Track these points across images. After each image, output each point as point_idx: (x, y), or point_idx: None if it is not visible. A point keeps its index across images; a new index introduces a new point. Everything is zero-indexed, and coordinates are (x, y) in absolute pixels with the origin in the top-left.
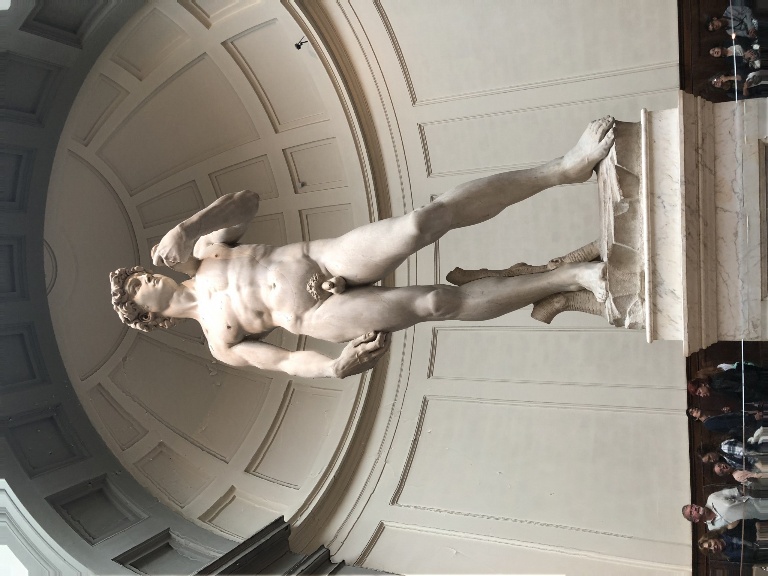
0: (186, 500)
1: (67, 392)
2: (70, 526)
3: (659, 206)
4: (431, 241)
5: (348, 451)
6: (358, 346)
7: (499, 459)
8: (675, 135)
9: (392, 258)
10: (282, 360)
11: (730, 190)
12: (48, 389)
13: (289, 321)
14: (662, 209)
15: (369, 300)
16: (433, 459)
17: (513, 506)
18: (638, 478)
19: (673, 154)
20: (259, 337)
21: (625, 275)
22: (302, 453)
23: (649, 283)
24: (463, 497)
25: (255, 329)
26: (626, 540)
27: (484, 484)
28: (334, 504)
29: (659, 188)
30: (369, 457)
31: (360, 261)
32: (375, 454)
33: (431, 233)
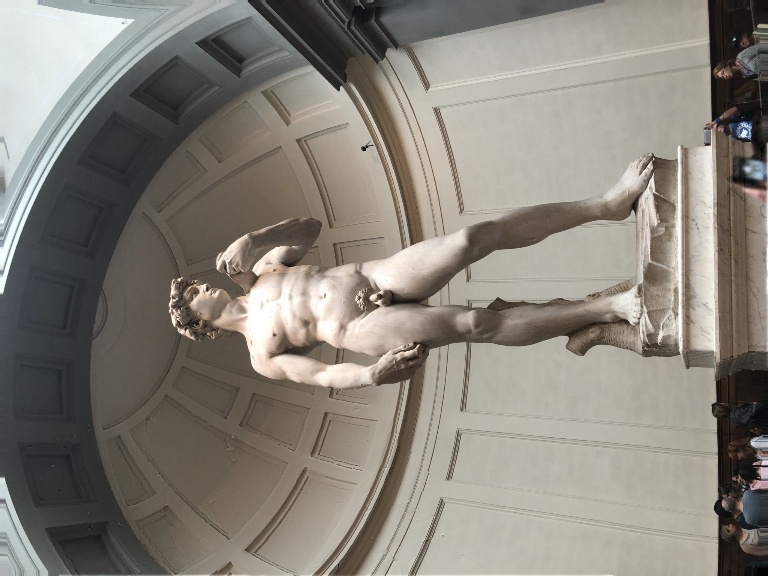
0: (180, 568)
1: (88, 436)
2: (63, 561)
3: (693, 228)
4: (478, 256)
5: (356, 542)
6: (397, 354)
7: (514, 570)
8: (709, 168)
9: (440, 272)
10: (319, 371)
11: (759, 215)
12: (71, 428)
13: (333, 330)
14: (696, 230)
15: (413, 312)
16: (444, 563)
17: None
18: None
19: (707, 183)
20: (300, 353)
21: (660, 290)
22: None
23: (682, 295)
24: None
25: (298, 340)
26: None
27: None
28: None
29: (693, 212)
30: (376, 553)
31: (409, 274)
32: (383, 550)
33: (479, 247)
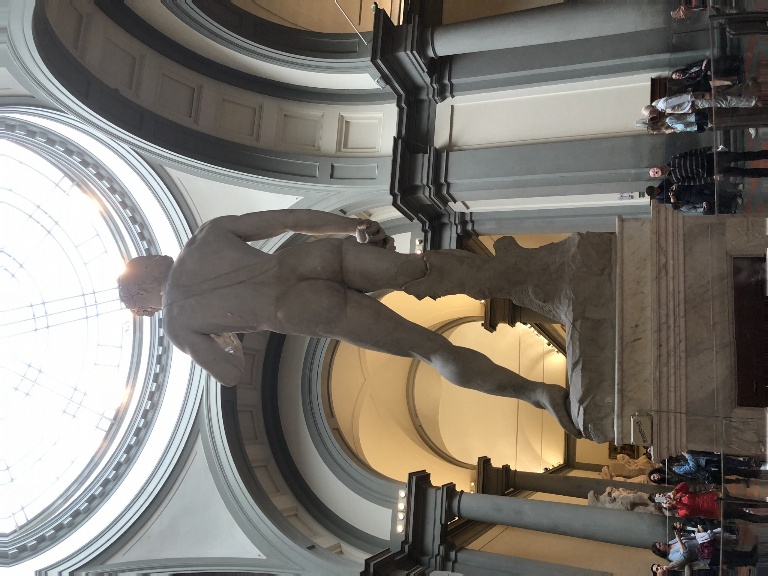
0: None
1: None
2: None
3: None
4: None
5: None
6: None
7: None
8: None
9: None
10: None
11: None
12: None
13: None
14: None
15: None
16: None
17: None
18: None
19: None
20: None
21: None
22: None
23: None
24: None
25: None
26: None
27: None
28: None
29: None
30: None
31: None
32: None
33: None
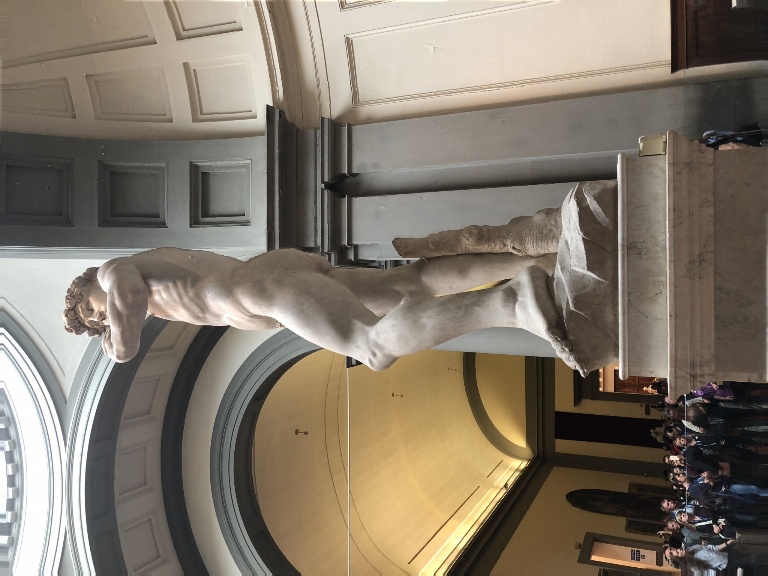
0: (164, 107)
1: None
2: (137, 227)
3: None
4: None
5: None
6: None
7: None
8: None
9: None
10: None
11: None
12: None
13: None
14: None
15: None
16: None
17: None
18: None
19: None
20: None
21: None
22: None
23: None
24: None
25: None
26: None
27: None
28: (290, 40)
29: None
30: None
31: None
32: None
33: None
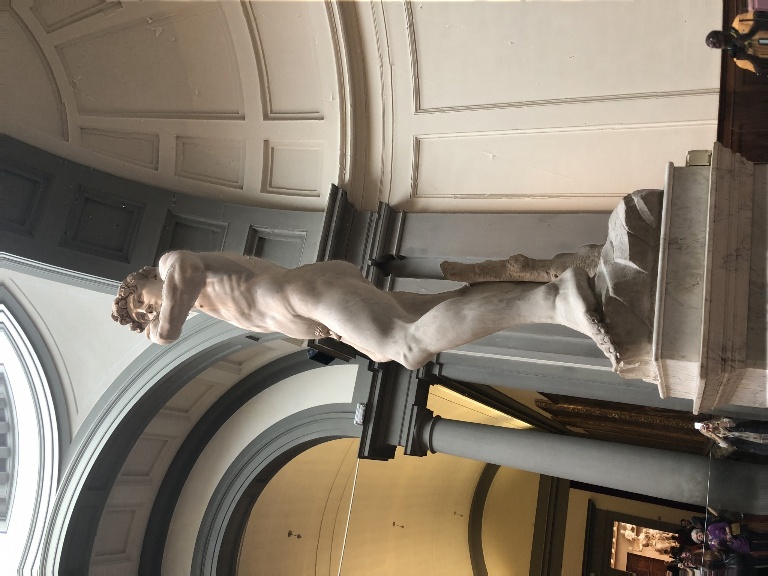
0: (238, 175)
1: (72, 167)
2: None
3: (674, 378)
4: None
5: (349, 69)
6: None
7: (507, 26)
8: (695, 368)
9: None
10: None
11: None
12: (59, 183)
13: None
14: (677, 379)
15: None
16: (437, 43)
17: (534, 83)
18: (665, 13)
19: None
20: None
21: None
22: (303, 76)
23: None
24: (481, 83)
25: None
26: (651, 102)
27: (498, 58)
28: (364, 132)
29: (674, 375)
30: (371, 59)
31: None
32: (376, 58)
33: None
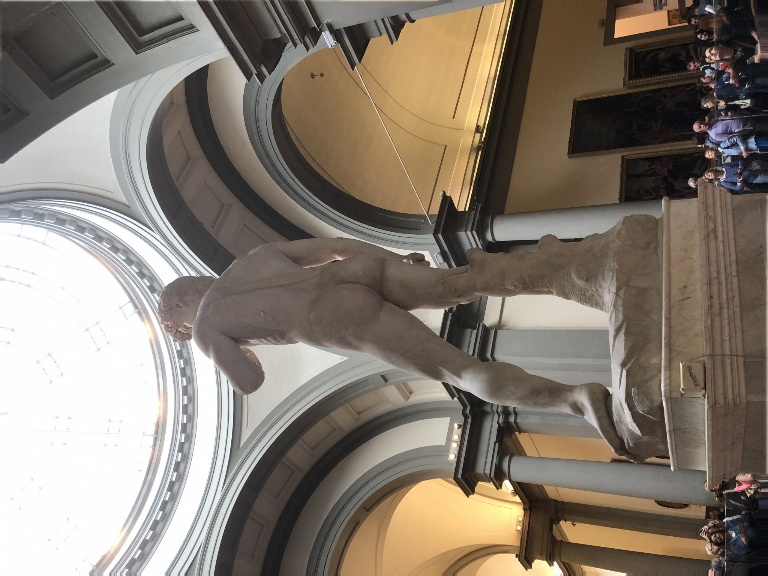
0: None
1: None
2: (86, 79)
3: None
4: None
5: None
6: None
7: None
8: None
9: None
10: None
11: None
12: None
13: None
14: None
15: None
16: None
17: None
18: None
19: None
20: None
21: None
22: None
23: None
24: None
25: None
26: None
27: None
28: None
29: None
30: None
31: None
32: None
33: None
